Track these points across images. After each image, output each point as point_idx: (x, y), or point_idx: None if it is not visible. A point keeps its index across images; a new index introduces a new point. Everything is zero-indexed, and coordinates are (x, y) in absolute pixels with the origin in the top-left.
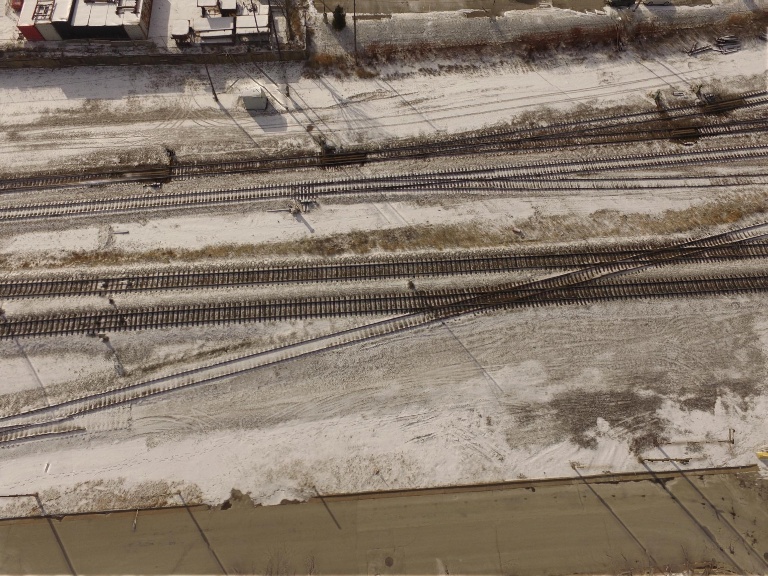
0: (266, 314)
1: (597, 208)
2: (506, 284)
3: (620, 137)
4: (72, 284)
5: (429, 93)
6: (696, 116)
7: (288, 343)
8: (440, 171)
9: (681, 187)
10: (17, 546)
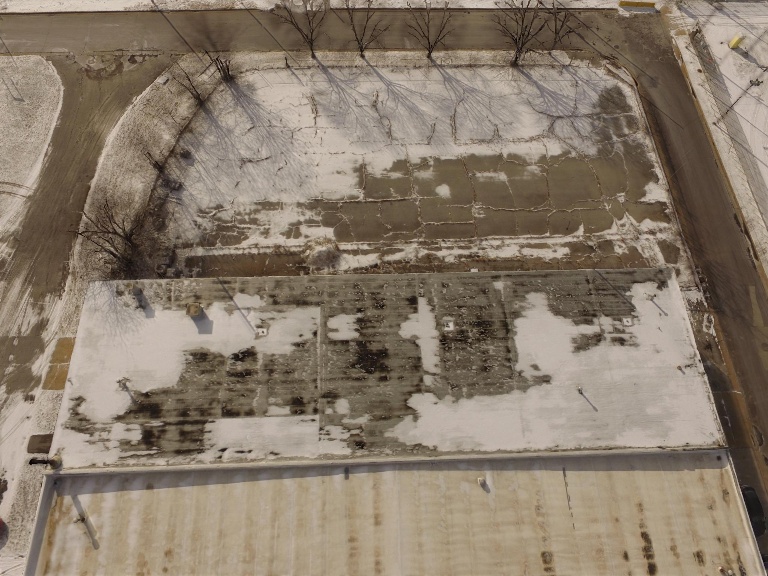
0: None
1: None
2: None
3: None
4: None
5: None
6: None
7: None
8: None
9: None
10: (143, 22)
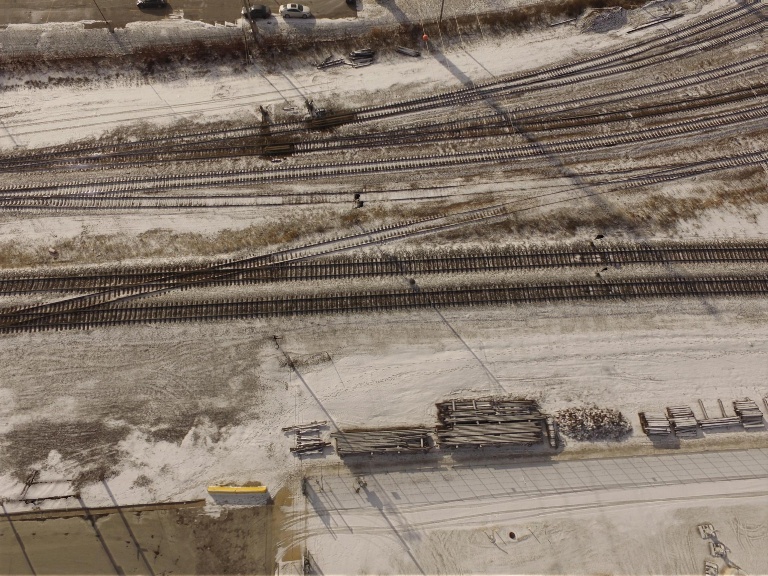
0: None
1: (150, 227)
2: (11, 308)
3: (208, 153)
4: None
5: (26, 106)
6: (298, 132)
7: None
8: None
9: (248, 206)
10: None
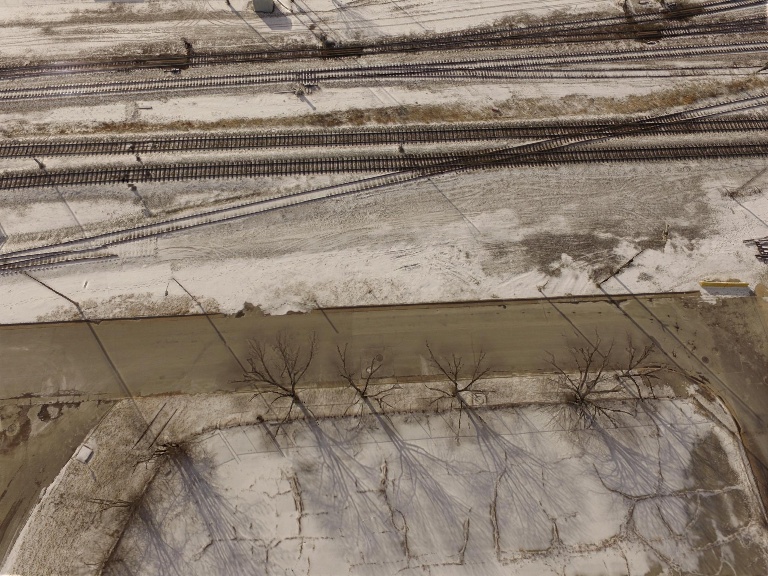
0: (274, 170)
1: (567, 93)
2: (485, 150)
3: (590, 37)
4: (103, 146)
5: (419, 0)
6: (659, 21)
7: (293, 193)
8: (428, 62)
9: (643, 77)
10: (62, 342)
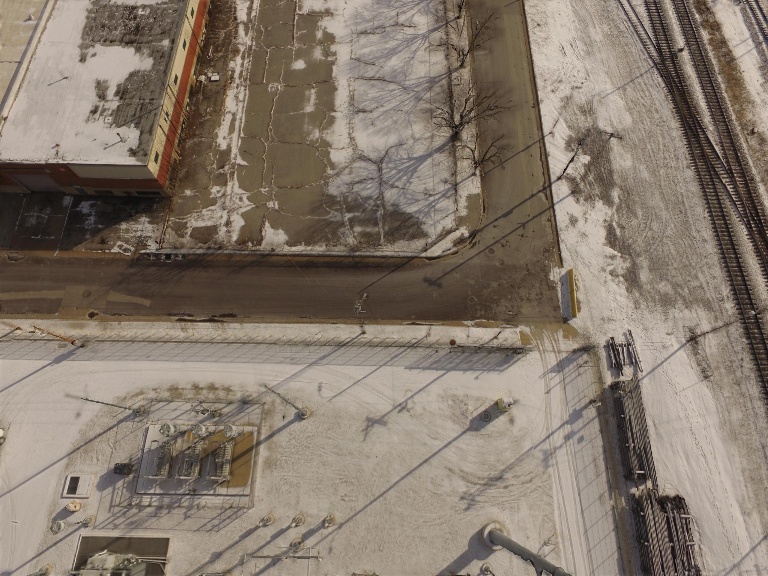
0: None
1: None
2: (697, 112)
3: None
4: None
5: None
6: None
7: None
8: None
9: None
10: None
